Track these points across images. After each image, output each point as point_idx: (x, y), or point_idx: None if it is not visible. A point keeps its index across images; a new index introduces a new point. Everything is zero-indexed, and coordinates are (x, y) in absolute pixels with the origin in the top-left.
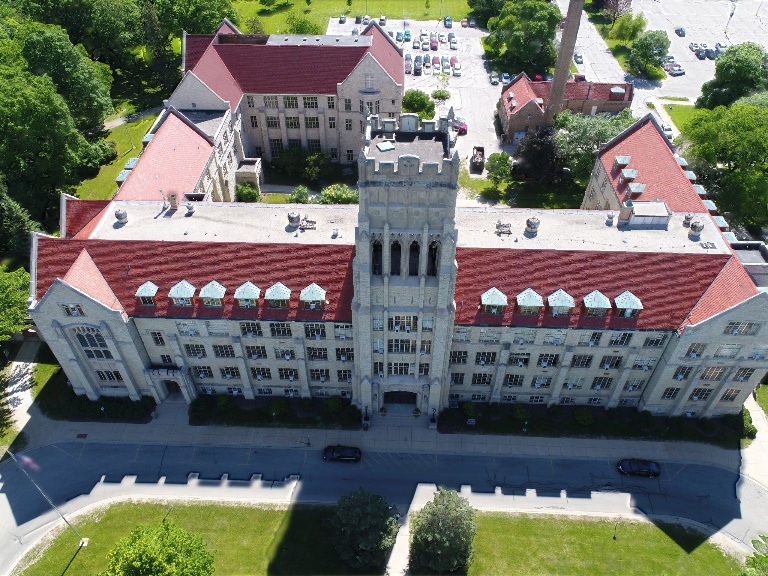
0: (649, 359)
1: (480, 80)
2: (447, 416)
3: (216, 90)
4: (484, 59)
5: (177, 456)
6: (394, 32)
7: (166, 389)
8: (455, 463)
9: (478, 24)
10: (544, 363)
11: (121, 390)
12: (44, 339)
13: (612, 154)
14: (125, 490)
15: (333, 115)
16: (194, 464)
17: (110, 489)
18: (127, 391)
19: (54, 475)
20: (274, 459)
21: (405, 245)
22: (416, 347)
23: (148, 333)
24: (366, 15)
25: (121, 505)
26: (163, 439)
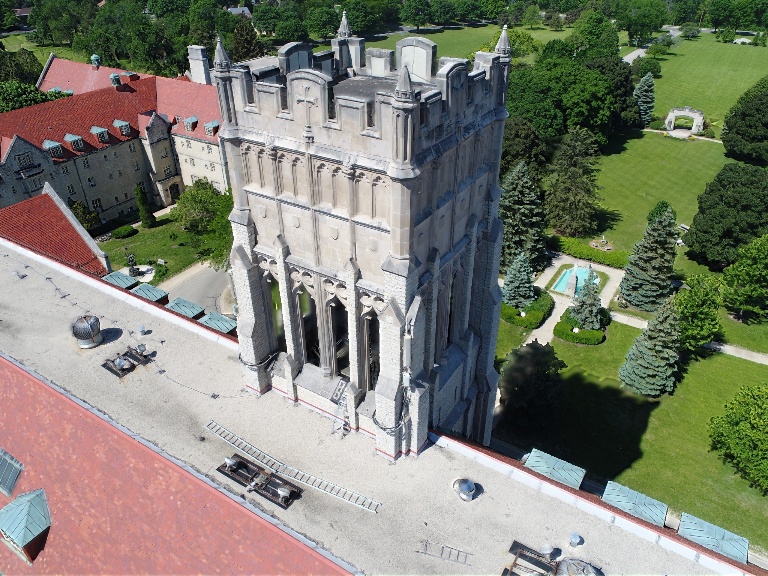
0: None
1: None
2: None
3: None
4: None
5: None
6: None
7: None
8: None
9: None
10: None
11: None
12: None
13: None
14: None
15: None
16: None
17: None
18: None
19: None
20: None
21: None
22: None
23: None
24: None
25: None
26: None
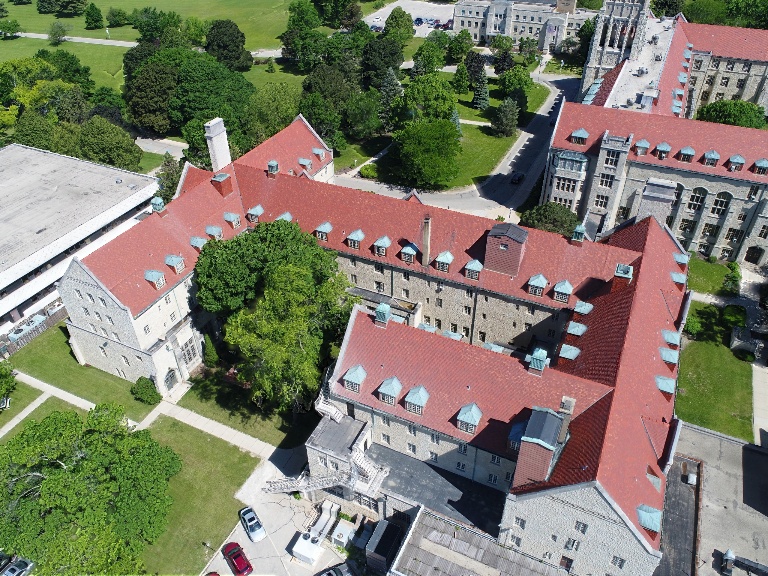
0: None
1: None
2: None
3: None
4: None
5: None
6: None
7: None
8: None
9: None
10: None
11: None
12: None
13: None
14: None
15: None
16: None
17: (557, 91)
18: None
19: None
20: None
21: None
22: None
23: None
24: None
25: None
26: None
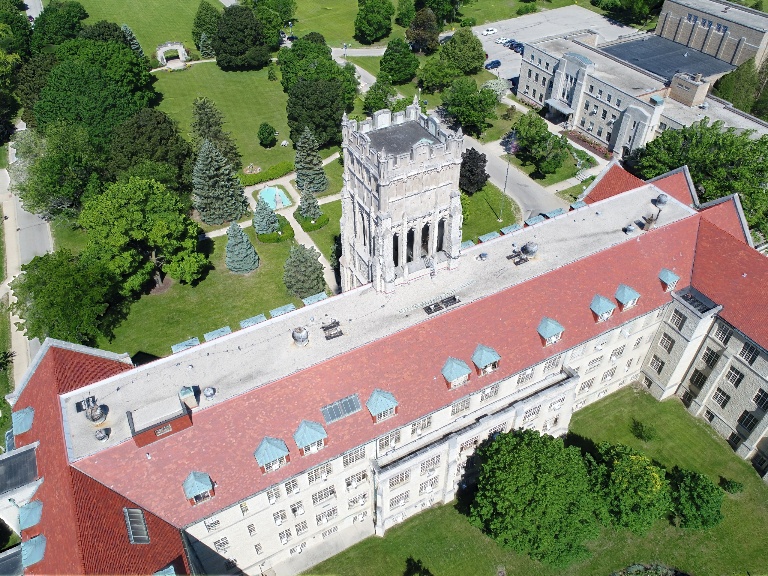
0: None
1: None
2: None
3: None
4: None
5: None
6: None
7: None
8: None
9: None
10: None
11: None
12: None
13: None
14: None
15: None
16: None
17: None
18: None
19: None
20: None
21: None
22: None
23: None
24: None
25: None
26: None
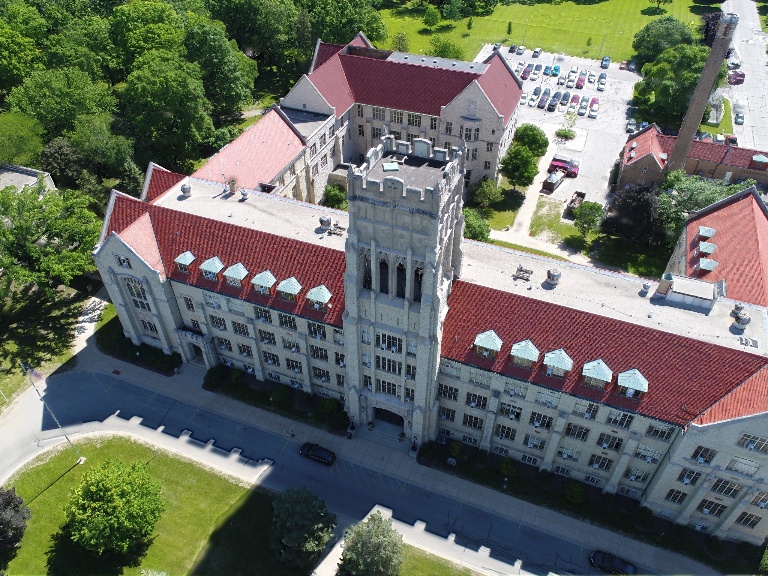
0: (654, 451)
1: (615, 125)
2: (429, 448)
3: (327, 95)
4: (629, 105)
5: (181, 412)
6: (544, 65)
7: (194, 351)
8: (420, 497)
9: (638, 68)
10: (537, 423)
11: (158, 342)
12: (103, 281)
13: (700, 224)
14: (129, 428)
15: (434, 136)
16: (191, 423)
17: (119, 423)
18: (162, 344)
19: (84, 398)
20: (258, 440)
21: (391, 265)
22: (402, 370)
23: (181, 297)
24: (522, 45)
25: (121, 439)
26: (176, 394)
